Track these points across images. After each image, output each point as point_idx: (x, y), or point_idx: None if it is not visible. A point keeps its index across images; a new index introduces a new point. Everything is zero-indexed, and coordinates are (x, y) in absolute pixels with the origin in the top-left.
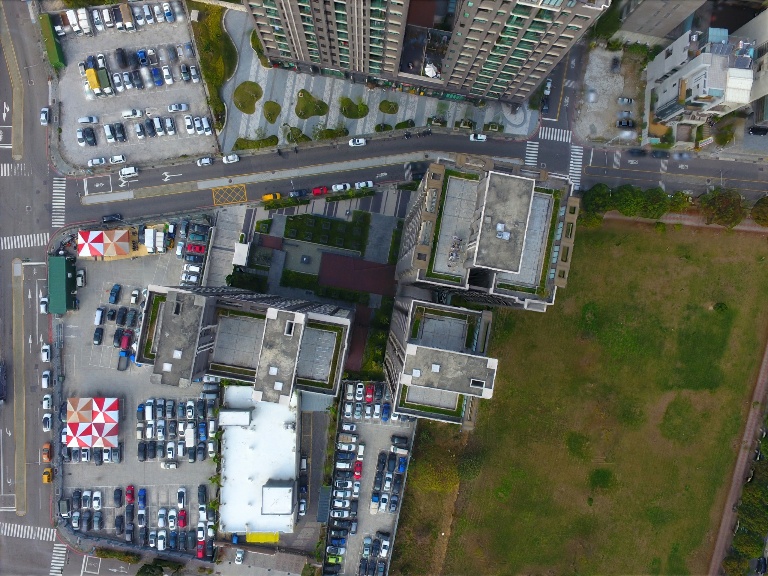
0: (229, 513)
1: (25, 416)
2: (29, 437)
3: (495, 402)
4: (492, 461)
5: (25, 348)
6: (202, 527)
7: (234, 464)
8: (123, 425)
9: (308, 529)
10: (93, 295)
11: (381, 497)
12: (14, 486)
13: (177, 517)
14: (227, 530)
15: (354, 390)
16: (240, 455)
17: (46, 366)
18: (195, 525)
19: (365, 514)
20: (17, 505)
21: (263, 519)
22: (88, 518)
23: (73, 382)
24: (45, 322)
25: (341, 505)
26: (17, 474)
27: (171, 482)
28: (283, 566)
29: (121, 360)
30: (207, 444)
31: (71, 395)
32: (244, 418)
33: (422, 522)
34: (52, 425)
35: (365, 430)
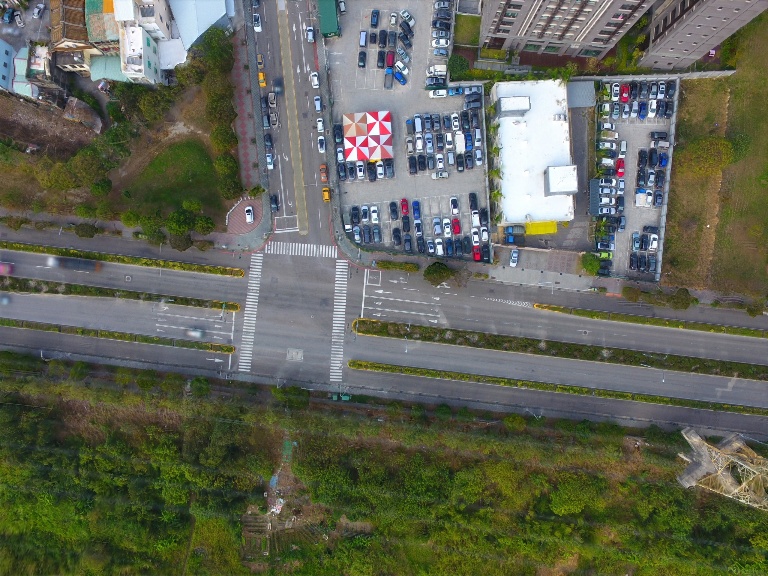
0: (509, 206)
1: (300, 141)
2: (305, 161)
3: (749, 93)
4: (751, 150)
5: (294, 77)
6: (477, 231)
7: (509, 159)
8: (392, 142)
9: (577, 229)
10: (353, 22)
11: (646, 192)
12: (295, 207)
13: (451, 224)
14: (508, 223)
15: (610, 90)
16: (514, 150)
17: (315, 93)
18: (468, 233)
19: (630, 212)
20: (299, 225)
21: (542, 210)
22: (369, 230)
23: (341, 106)
24: (311, 52)
25: (608, 201)
26: (297, 196)
27: (441, 193)
28: (555, 267)
29: (386, 79)
30: (473, 154)
31: (340, 118)
32: (524, 102)
33: (686, 216)
34: (325, 147)
35: (623, 131)
